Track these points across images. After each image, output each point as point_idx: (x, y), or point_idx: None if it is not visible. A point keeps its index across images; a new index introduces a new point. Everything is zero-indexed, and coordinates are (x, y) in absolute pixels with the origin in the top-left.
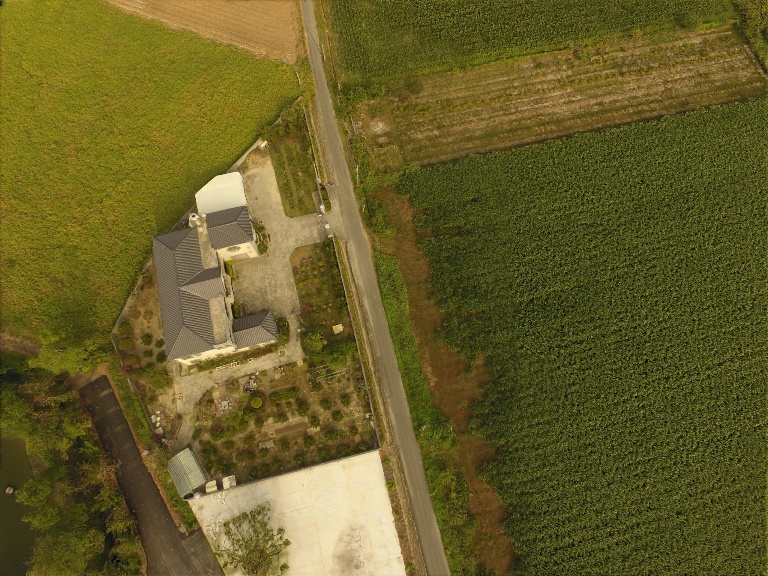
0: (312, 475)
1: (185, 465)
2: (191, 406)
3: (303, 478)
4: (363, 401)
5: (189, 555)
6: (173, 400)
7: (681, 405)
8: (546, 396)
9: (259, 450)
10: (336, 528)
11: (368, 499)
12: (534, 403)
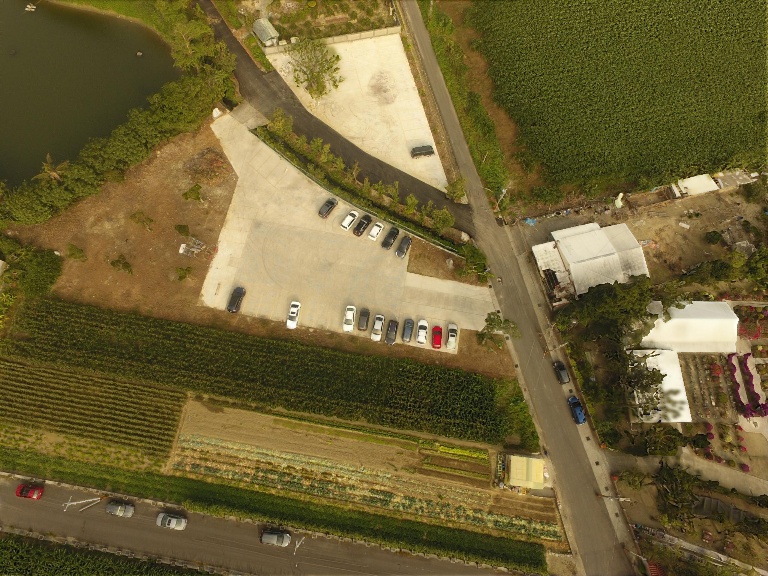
0: (352, 45)
1: (265, 25)
2: (265, 7)
3: (346, 46)
4: (388, 7)
5: (268, 82)
6: (252, 4)
7: (617, 8)
8: (519, 2)
9: (315, 30)
10: (370, 72)
11: (392, 58)
12: (511, 6)
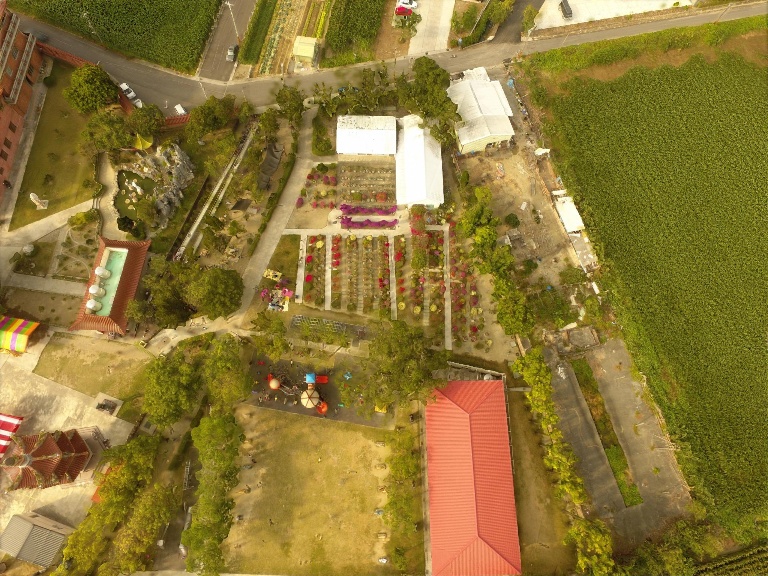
0: None
1: None
2: None
3: None
4: None
5: None
6: None
7: None
8: (764, 93)
9: None
10: None
11: None
12: None
